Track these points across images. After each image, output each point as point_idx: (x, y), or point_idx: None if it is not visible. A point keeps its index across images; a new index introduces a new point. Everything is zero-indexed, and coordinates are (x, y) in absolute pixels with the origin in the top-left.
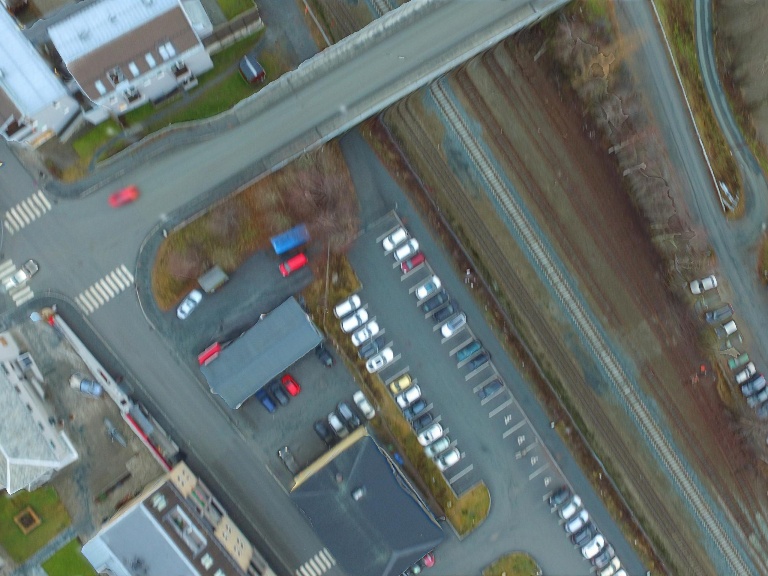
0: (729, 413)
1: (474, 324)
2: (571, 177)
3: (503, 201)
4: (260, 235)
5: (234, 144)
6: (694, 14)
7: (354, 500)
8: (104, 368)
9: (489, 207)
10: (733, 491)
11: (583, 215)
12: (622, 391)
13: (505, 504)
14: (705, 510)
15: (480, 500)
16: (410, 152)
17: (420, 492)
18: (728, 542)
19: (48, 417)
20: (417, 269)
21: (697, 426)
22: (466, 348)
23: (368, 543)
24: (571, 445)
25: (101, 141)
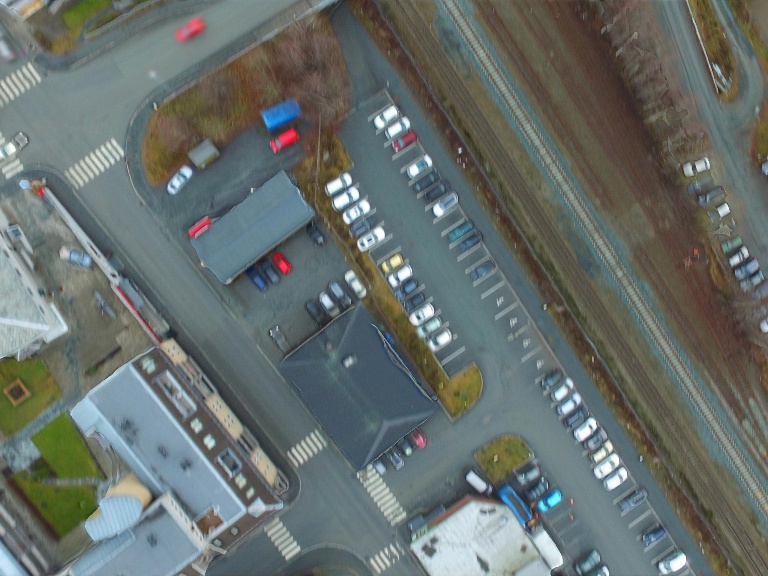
0: (722, 297)
1: (466, 204)
2: (563, 58)
3: (495, 81)
4: (251, 110)
5: (224, 15)
6: None
7: (344, 368)
8: (94, 243)
9: (481, 87)
10: (726, 376)
11: (575, 96)
12: (615, 274)
13: (497, 386)
14: (698, 395)
15: (472, 382)
16: (402, 31)
17: (412, 373)
18: (721, 427)
19: (37, 288)
20: (409, 149)
21: (690, 310)
22: (458, 228)
23: (359, 412)
24: (563, 328)
25: (91, 13)
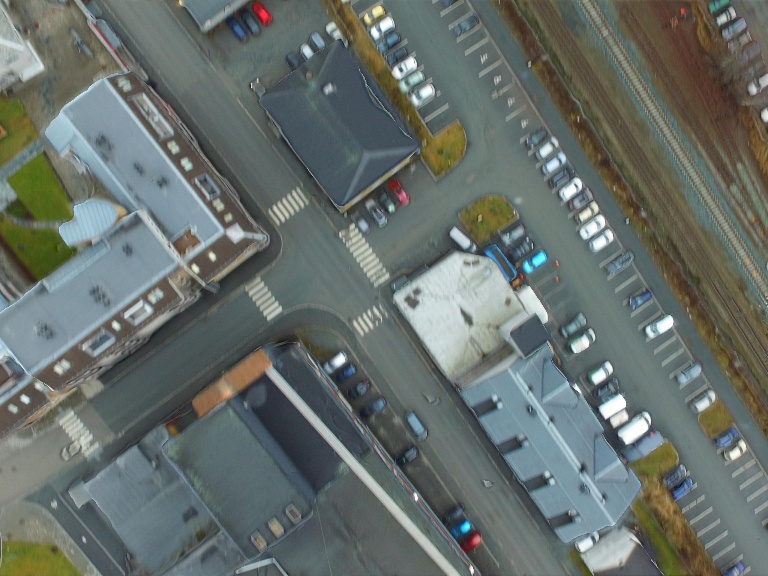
0: (709, 59)
1: None
2: None
3: None
4: None
5: None
6: None
7: (324, 96)
8: None
9: None
10: (714, 139)
11: None
12: (600, 33)
13: (481, 145)
14: (685, 158)
15: (456, 139)
16: None
17: None
18: (709, 191)
19: (13, 23)
20: None
21: (677, 71)
22: None
23: (339, 143)
24: (548, 86)
25: None
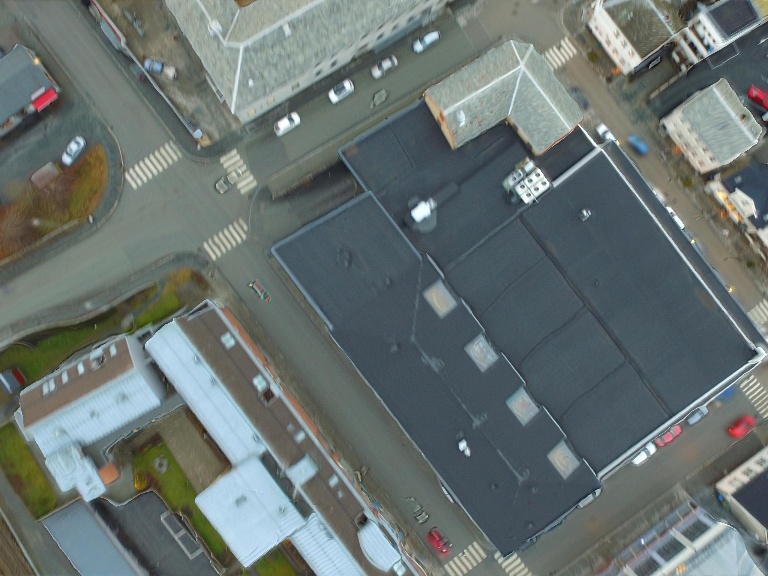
0: None
1: None
2: None
3: None
4: (2, 219)
5: (18, 306)
6: None
7: None
8: None
9: None
10: None
11: None
12: None
13: None
14: None
15: None
16: None
17: None
18: None
19: None
20: None
21: None
22: None
23: None
24: None
25: (154, 308)
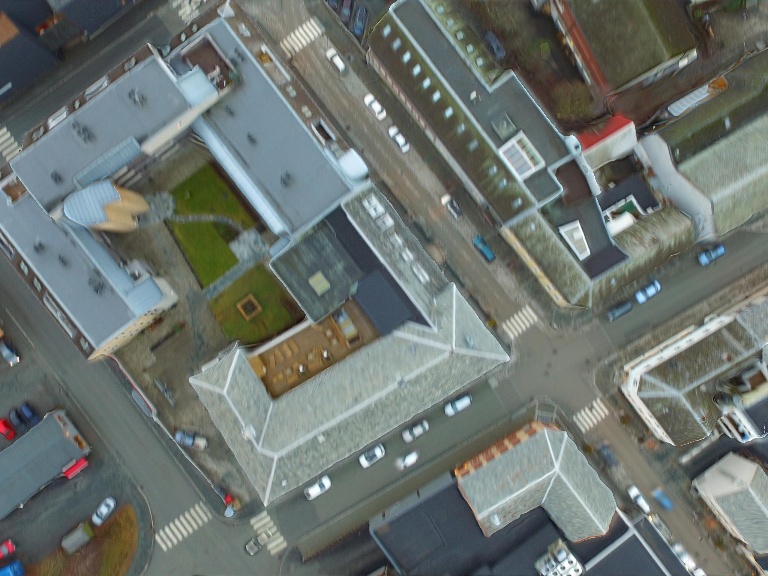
0: None
1: None
2: None
3: None
4: None
5: None
6: None
7: None
8: None
9: None
10: None
11: None
12: None
13: None
14: None
15: None
16: None
17: None
18: None
19: None
20: None
21: None
22: None
23: None
24: None
25: None
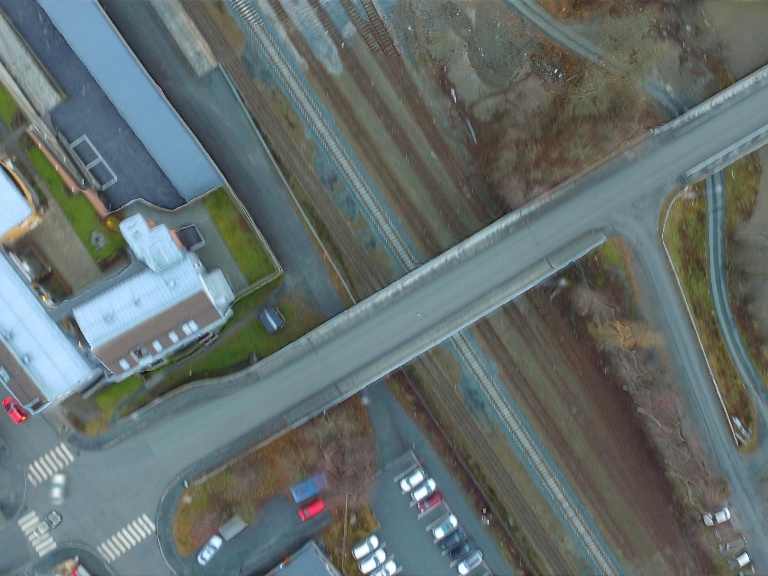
0: None
1: (490, 560)
2: (586, 413)
3: (519, 438)
4: (279, 482)
5: (254, 398)
6: (707, 250)
7: None
8: None
9: (505, 444)
10: None
11: (598, 450)
12: None
13: None
14: None
15: None
16: (427, 392)
17: None
18: None
19: None
20: (434, 507)
21: None
22: None
23: None
24: None
25: (123, 395)
